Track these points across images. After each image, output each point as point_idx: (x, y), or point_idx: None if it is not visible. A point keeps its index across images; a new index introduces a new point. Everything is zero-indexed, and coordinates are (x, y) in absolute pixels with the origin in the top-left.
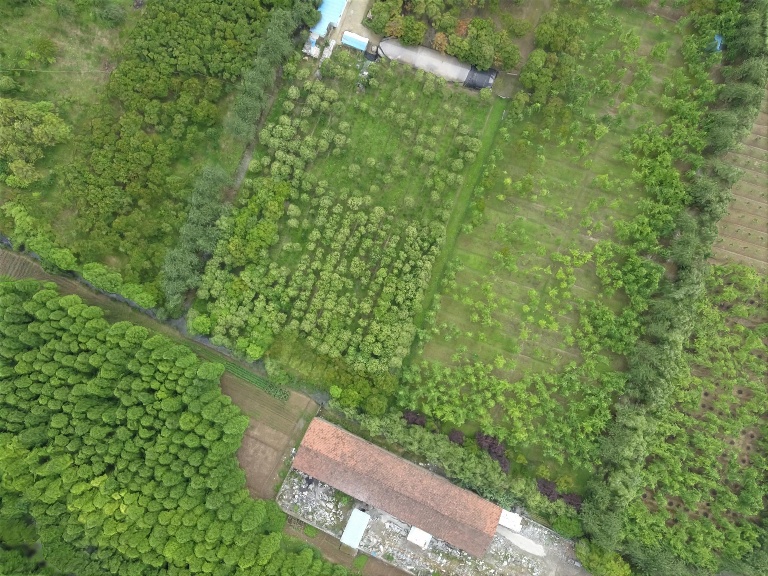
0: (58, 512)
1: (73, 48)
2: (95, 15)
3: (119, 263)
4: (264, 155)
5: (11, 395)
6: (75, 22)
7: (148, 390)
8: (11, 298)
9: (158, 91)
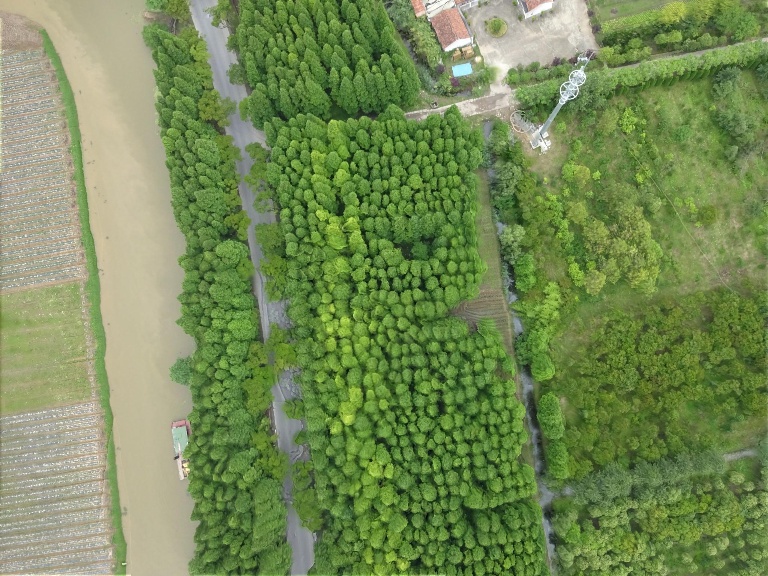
0: (358, 550)
1: (720, 232)
2: (765, 233)
3: (563, 408)
4: (753, 481)
5: (424, 439)
6: (745, 219)
7: (502, 547)
8: (494, 367)
9: (745, 348)
